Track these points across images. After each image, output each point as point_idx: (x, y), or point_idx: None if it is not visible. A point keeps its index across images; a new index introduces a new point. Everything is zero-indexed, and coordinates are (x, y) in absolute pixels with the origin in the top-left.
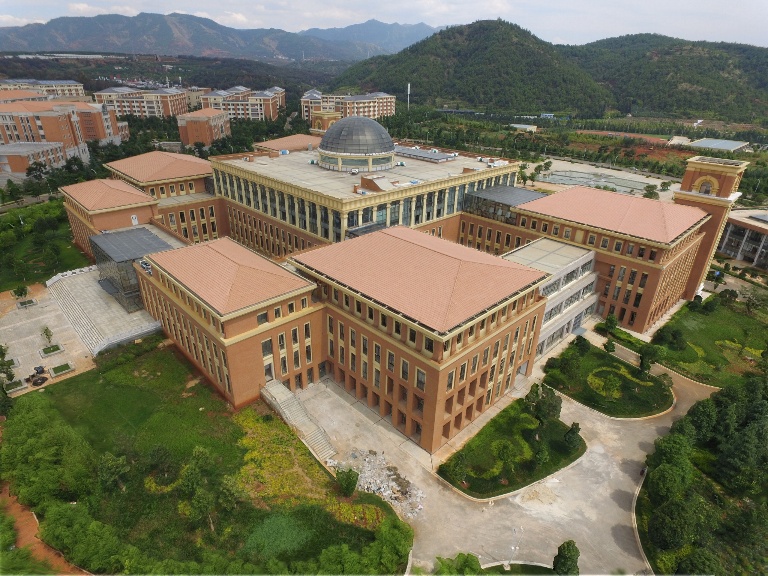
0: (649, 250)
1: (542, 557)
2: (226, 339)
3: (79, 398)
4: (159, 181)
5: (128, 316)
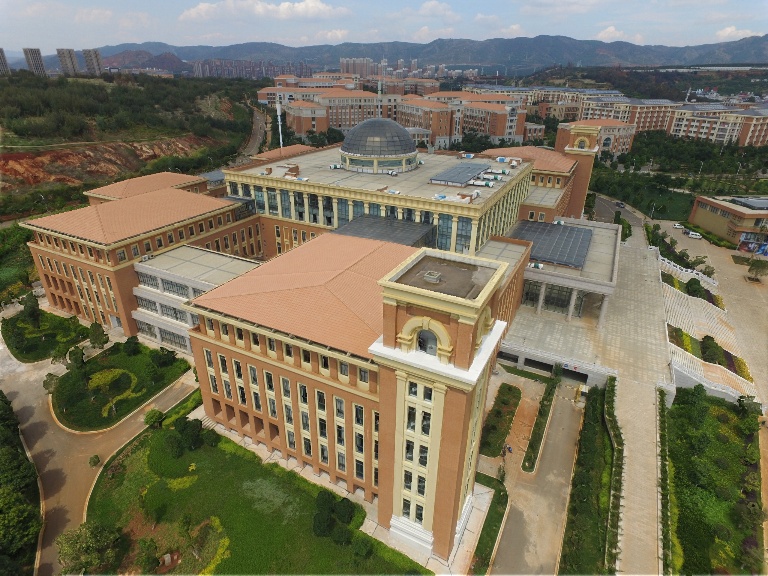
0: None
1: None
2: None
3: None
4: None
5: None
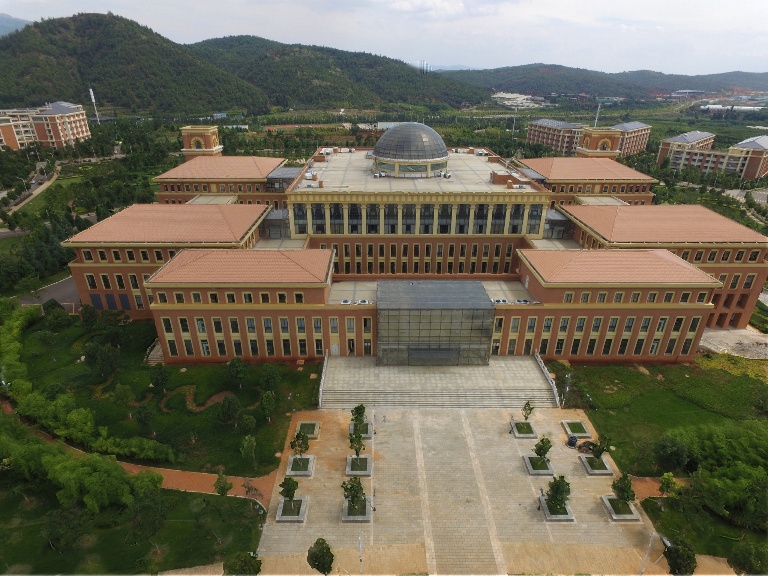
0: (642, 186)
1: None
2: (709, 303)
3: (640, 429)
4: (247, 235)
5: (493, 367)
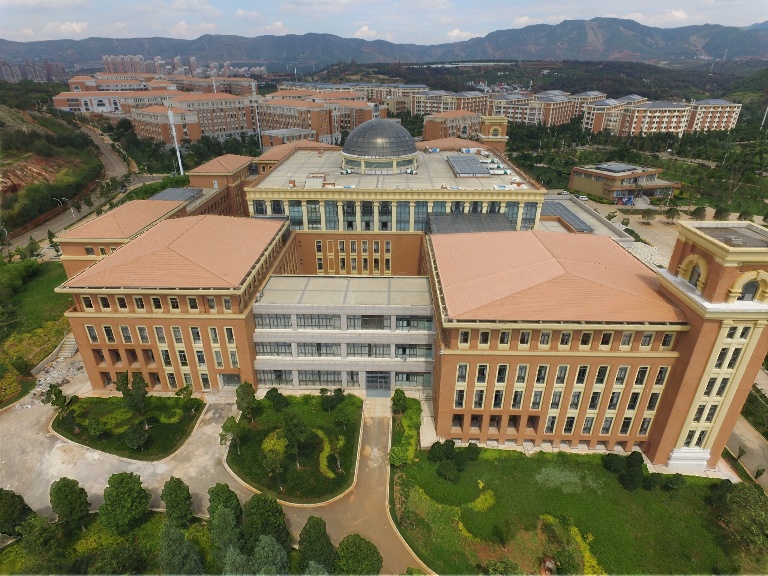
0: None
1: None
2: (63, 255)
3: None
4: (266, 161)
5: None
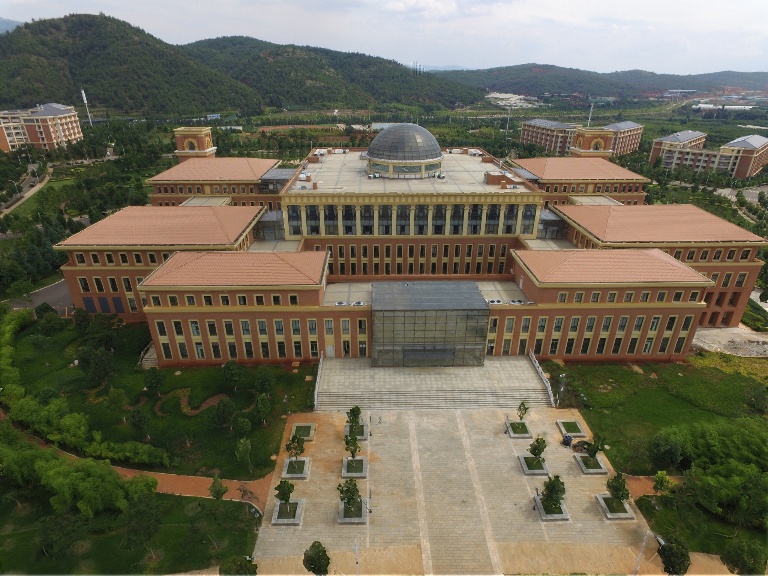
0: (635, 186)
1: None
2: (702, 302)
3: (634, 427)
4: (241, 237)
5: (488, 368)
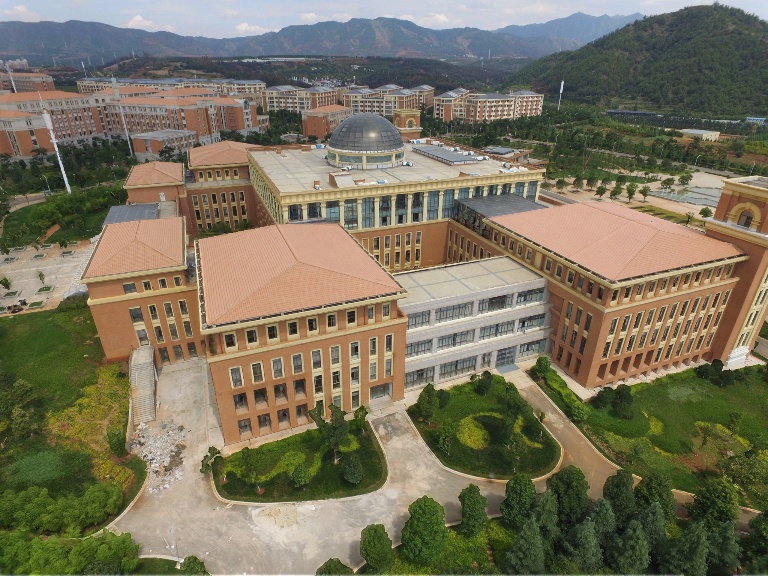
0: (597, 286)
1: (219, 571)
2: (91, 299)
3: (25, 328)
4: (205, 166)
5: None
